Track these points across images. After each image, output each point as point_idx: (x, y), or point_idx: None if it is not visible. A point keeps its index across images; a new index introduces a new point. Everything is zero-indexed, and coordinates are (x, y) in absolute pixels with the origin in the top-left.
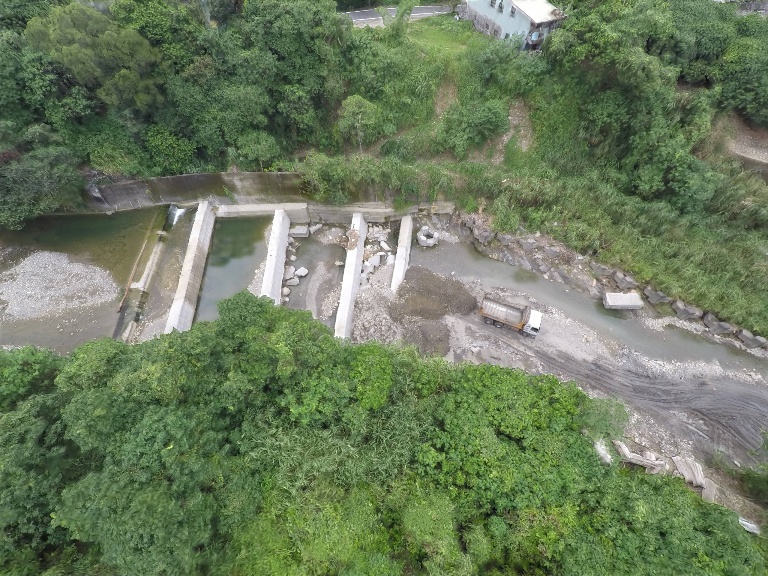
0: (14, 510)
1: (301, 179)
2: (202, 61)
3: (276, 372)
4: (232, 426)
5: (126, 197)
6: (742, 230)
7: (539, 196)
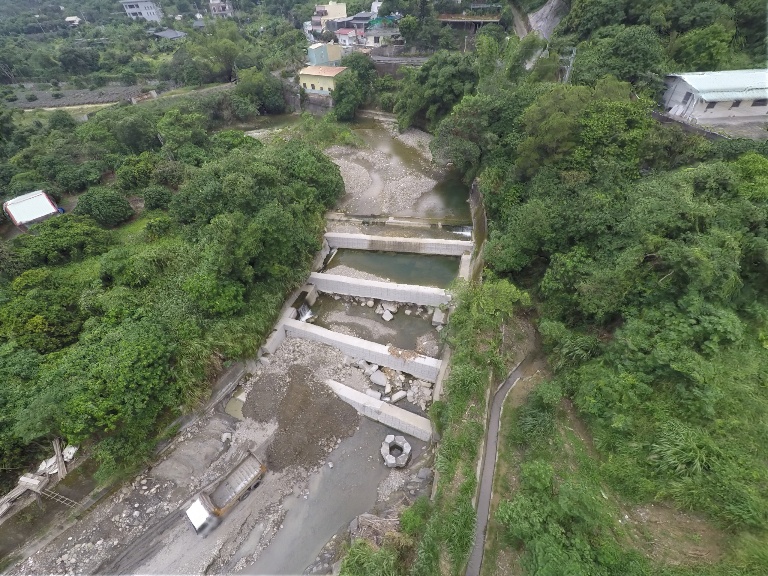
0: None
1: None
2: (582, 176)
3: None
4: None
5: None
6: None
7: None
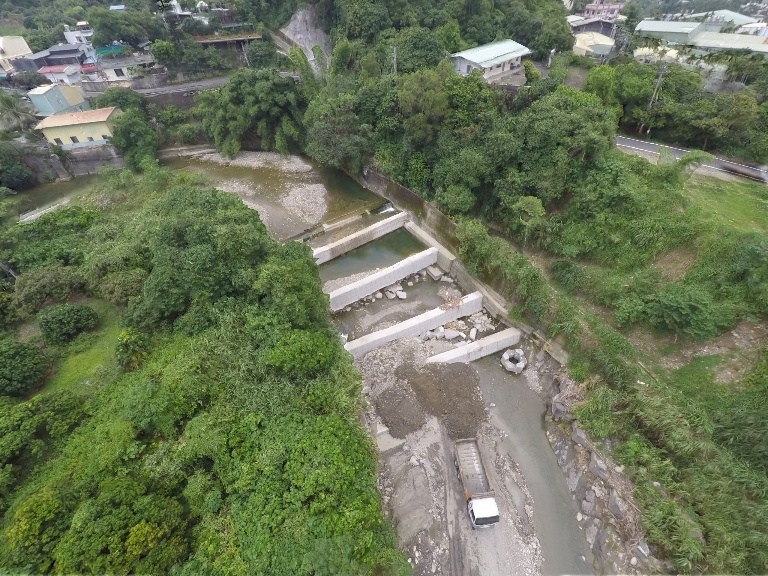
0: (161, 241)
1: None
2: (473, 127)
3: (264, 290)
4: (231, 295)
5: (376, 184)
6: None
7: (664, 433)
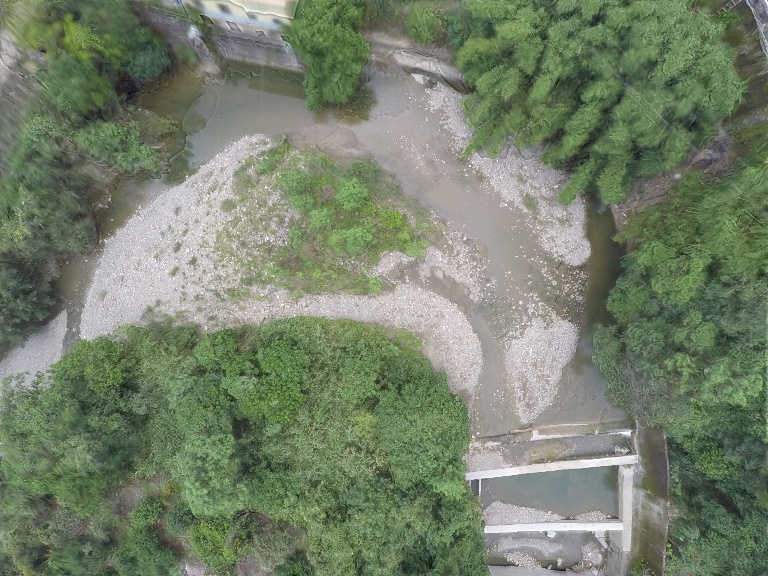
0: None
1: (656, 570)
2: None
3: None
4: None
5: None
6: None
7: None
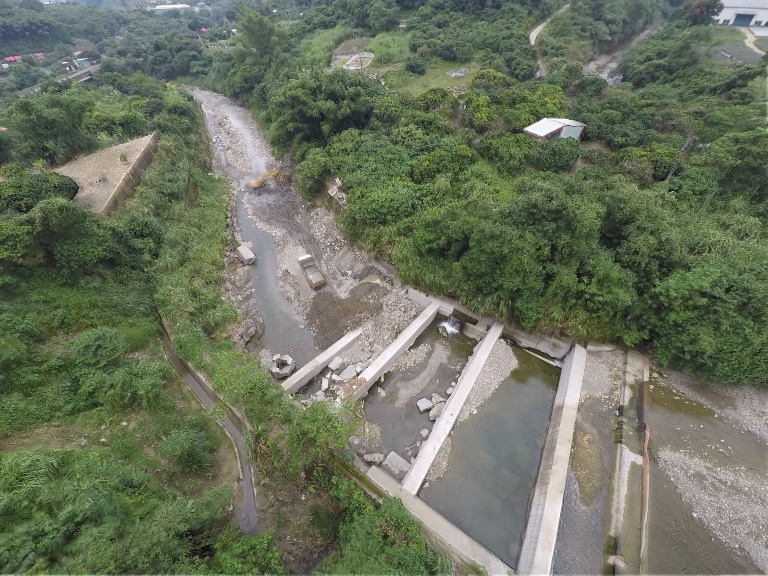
0: None
1: (356, 476)
2: None
3: None
4: None
5: None
6: (162, 218)
7: None
